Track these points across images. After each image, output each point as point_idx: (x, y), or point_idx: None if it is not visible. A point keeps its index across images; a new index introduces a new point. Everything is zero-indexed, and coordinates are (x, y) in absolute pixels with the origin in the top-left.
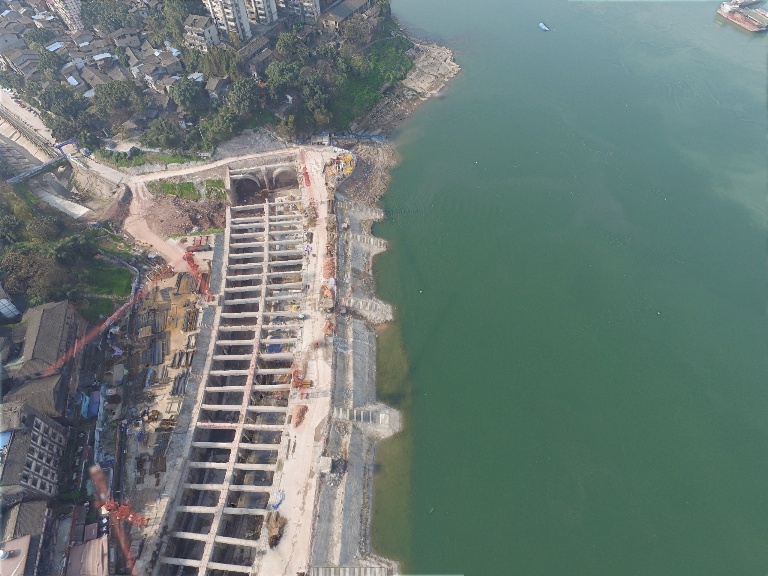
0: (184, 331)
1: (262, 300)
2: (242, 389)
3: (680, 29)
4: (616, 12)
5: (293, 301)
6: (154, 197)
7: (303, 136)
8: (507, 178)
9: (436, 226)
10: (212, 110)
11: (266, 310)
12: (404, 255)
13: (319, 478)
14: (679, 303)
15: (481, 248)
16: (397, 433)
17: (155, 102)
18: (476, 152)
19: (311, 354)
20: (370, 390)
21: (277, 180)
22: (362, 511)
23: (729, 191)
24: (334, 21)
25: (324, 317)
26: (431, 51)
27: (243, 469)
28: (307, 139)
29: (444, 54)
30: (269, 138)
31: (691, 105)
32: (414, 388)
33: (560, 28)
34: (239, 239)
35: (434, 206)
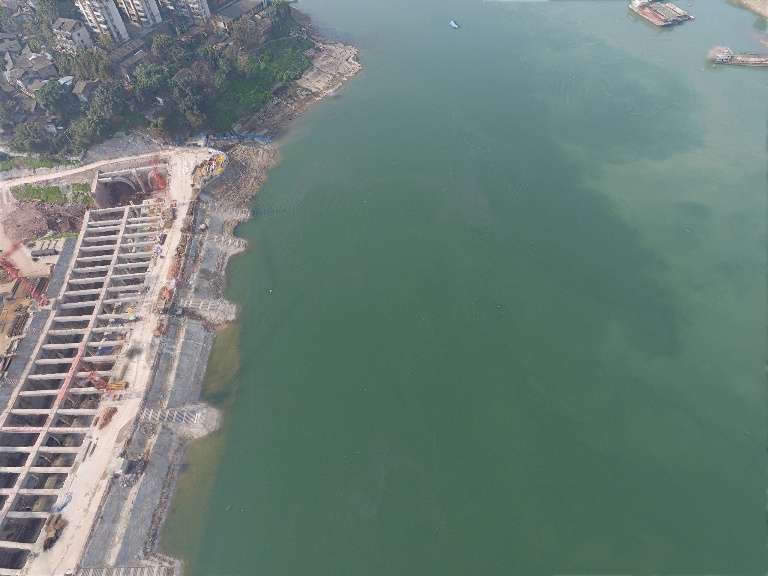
0: (8, 336)
1: (99, 303)
2: (56, 392)
3: (589, 25)
4: (530, 9)
5: (136, 303)
6: (18, 202)
7: (179, 138)
8: (382, 176)
9: (300, 225)
10: (82, 113)
11: (107, 313)
12: (262, 255)
13: (111, 479)
14: (524, 296)
15: (339, 246)
16: (212, 432)
17: (22, 106)
18: (357, 150)
19: (134, 356)
20: (193, 390)
21: (153, 182)
22: (156, 511)
23: (595, 184)
24: (222, 22)
25: (157, 318)
26: (332, 50)
27: (39, 472)
28: (184, 141)
29: (346, 53)
30: (143, 140)
31: (581, 100)
32: (240, 387)
33: (470, 25)
34: (101, 242)
35: (303, 205)
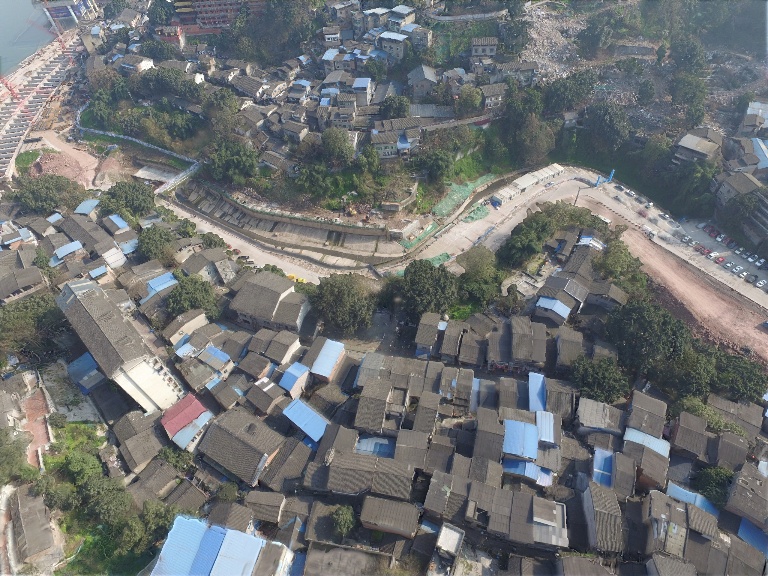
0: None
1: (4, 128)
2: None
3: None
4: None
5: None
6: None
7: None
8: None
9: None
10: None
11: None
12: None
13: None
14: None
15: None
16: None
17: None
18: None
19: None
20: None
21: None
22: None
23: None
24: None
25: None
26: None
27: None
28: None
29: None
30: None
31: None
32: None
33: None
34: None
35: None
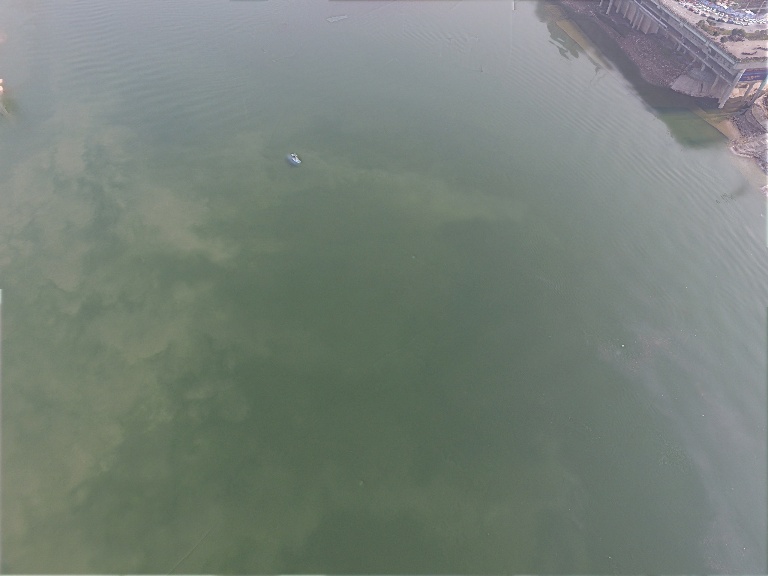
0: None
1: None
2: None
3: None
4: None
5: None
6: None
7: None
8: None
9: None
10: None
11: None
12: None
13: None
14: (595, 367)
15: None
16: None
17: None
18: None
19: None
20: None
21: None
22: None
23: None
24: None
25: None
26: None
27: None
28: None
29: None
30: None
31: None
32: None
33: None
34: None
35: None
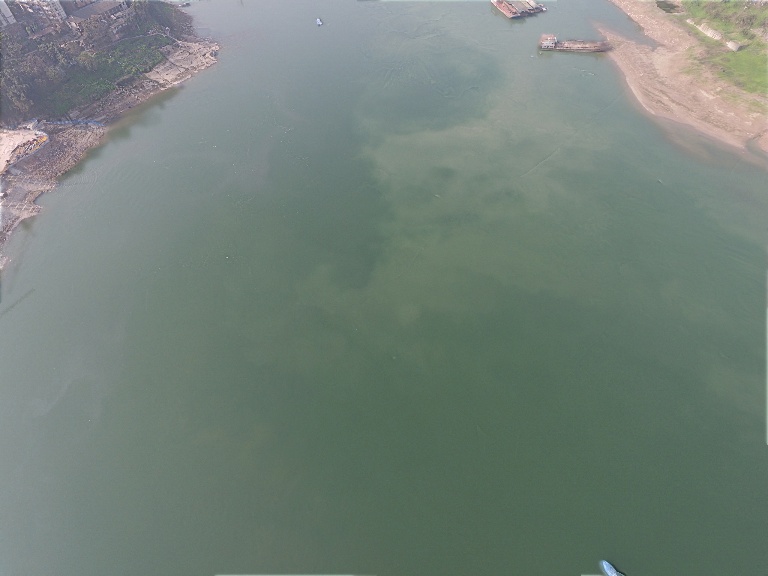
0: None
1: None
2: None
3: (446, 19)
4: (400, 6)
5: None
6: None
7: (13, 122)
8: (185, 153)
9: (95, 194)
10: None
11: None
12: (51, 218)
13: None
14: (258, 250)
15: None
16: None
17: None
18: (174, 132)
19: None
20: None
21: None
22: None
23: (365, 156)
24: (74, 22)
25: None
26: (191, 47)
27: None
28: None
29: (205, 49)
30: None
31: (400, 85)
32: None
33: (334, 22)
34: None
35: (105, 178)
